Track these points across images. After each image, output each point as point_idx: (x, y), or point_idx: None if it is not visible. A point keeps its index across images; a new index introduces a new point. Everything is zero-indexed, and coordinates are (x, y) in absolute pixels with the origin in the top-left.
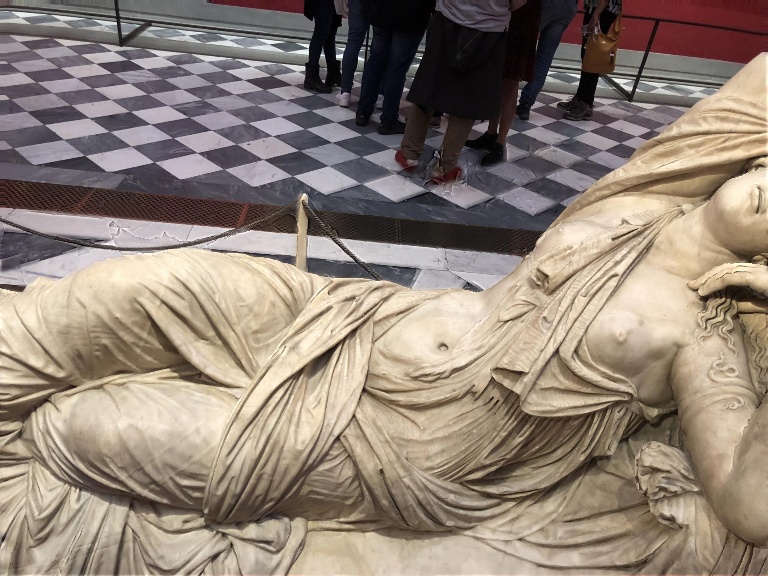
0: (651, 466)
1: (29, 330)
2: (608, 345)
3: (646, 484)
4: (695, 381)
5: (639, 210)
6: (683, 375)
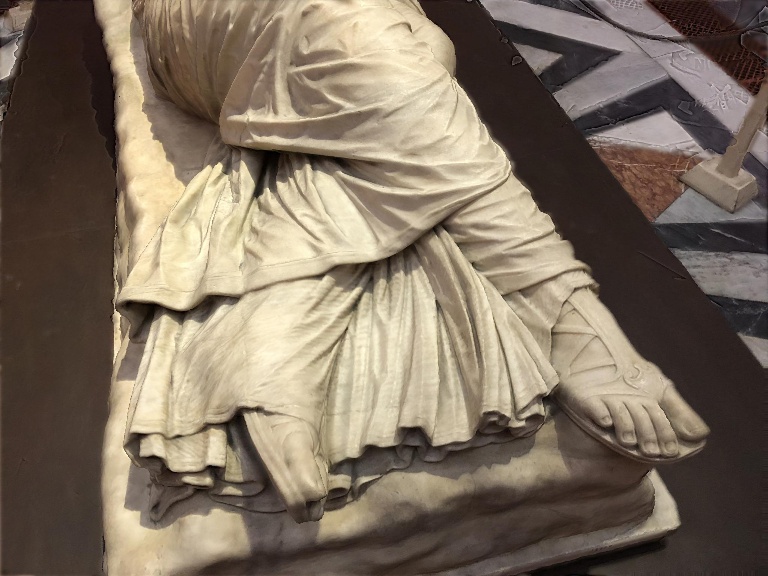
0: None
1: (408, 22)
2: None
3: None
4: None
5: None
6: None
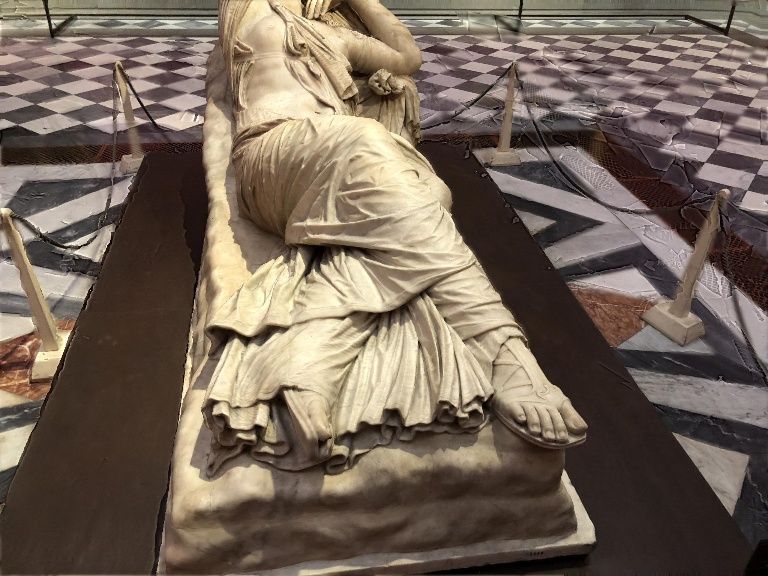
0: (387, 78)
1: (416, 171)
2: (346, 50)
3: (390, 87)
4: (358, 44)
5: (265, 0)
6: (352, 47)
